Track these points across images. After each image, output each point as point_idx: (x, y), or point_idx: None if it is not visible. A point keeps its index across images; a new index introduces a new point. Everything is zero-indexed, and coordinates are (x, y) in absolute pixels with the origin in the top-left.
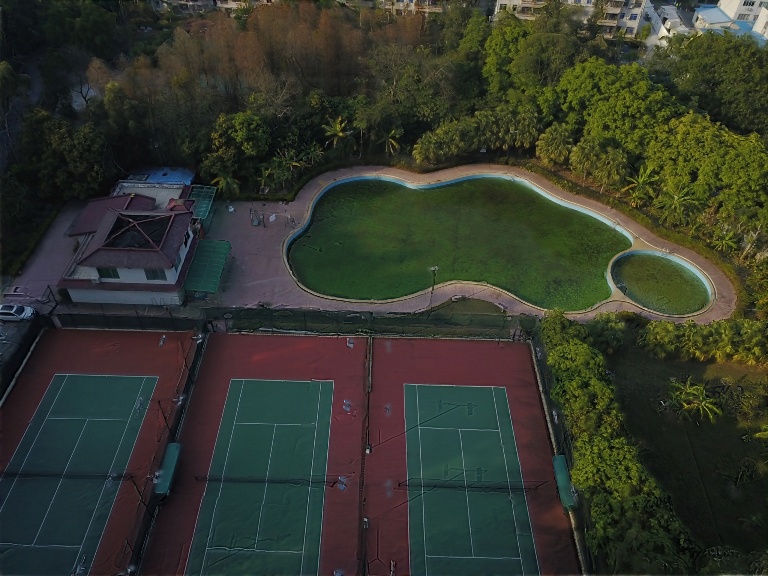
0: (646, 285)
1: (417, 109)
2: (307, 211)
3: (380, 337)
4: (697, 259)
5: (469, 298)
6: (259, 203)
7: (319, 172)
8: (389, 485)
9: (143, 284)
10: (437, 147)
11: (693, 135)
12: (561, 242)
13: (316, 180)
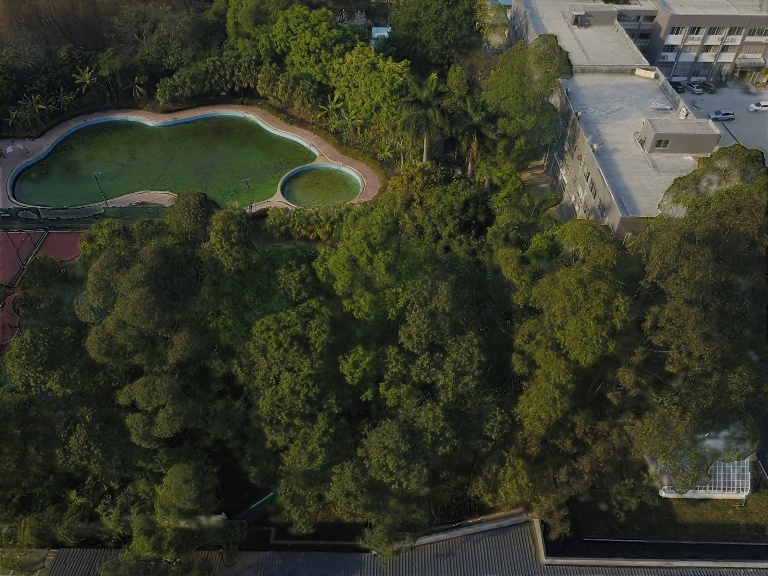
0: (310, 190)
1: (165, 60)
2: (47, 145)
3: (55, 231)
4: (363, 169)
5: (148, 203)
6: (8, 140)
7: (73, 115)
8: (3, 327)
9: None
10: (173, 90)
11: (355, 64)
12: (258, 161)
13: (68, 122)
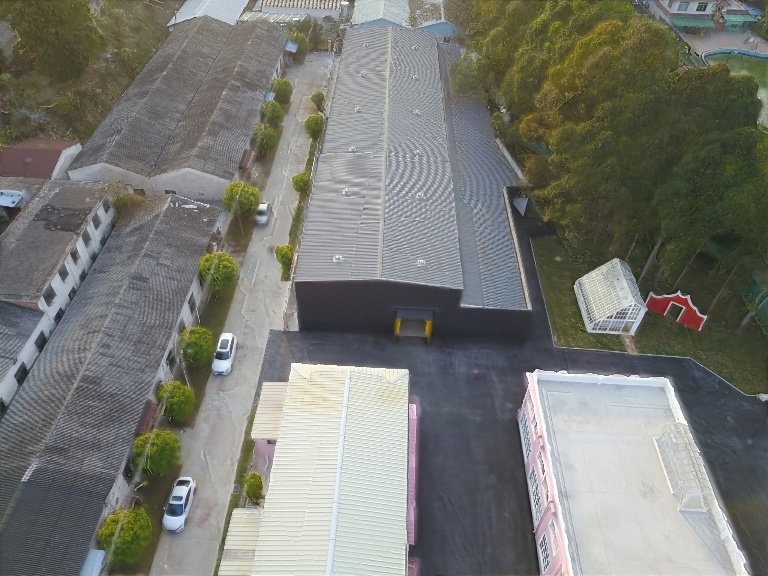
0: None
1: None
2: None
3: None
4: None
5: None
6: (764, 41)
7: None
8: None
9: (665, 7)
10: None
11: None
12: None
13: None
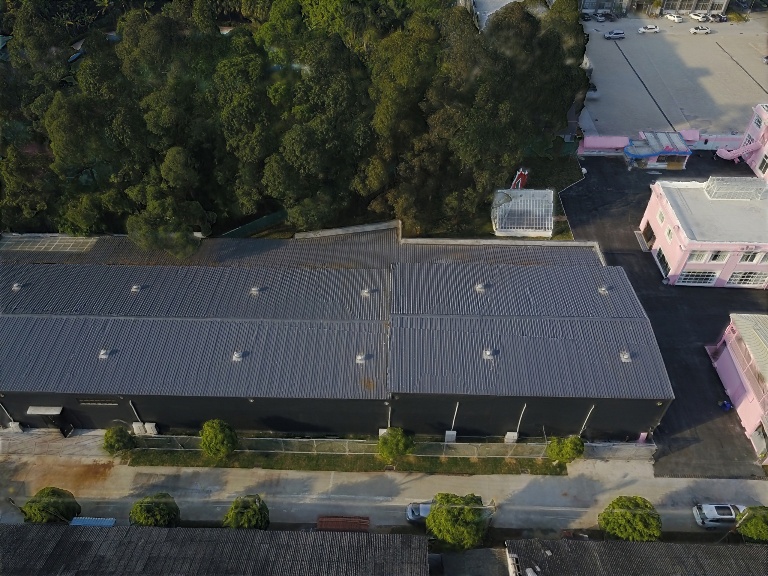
0: None
1: None
2: None
3: None
4: None
5: None
6: None
7: None
8: None
9: None
10: None
11: None
12: None
13: None
